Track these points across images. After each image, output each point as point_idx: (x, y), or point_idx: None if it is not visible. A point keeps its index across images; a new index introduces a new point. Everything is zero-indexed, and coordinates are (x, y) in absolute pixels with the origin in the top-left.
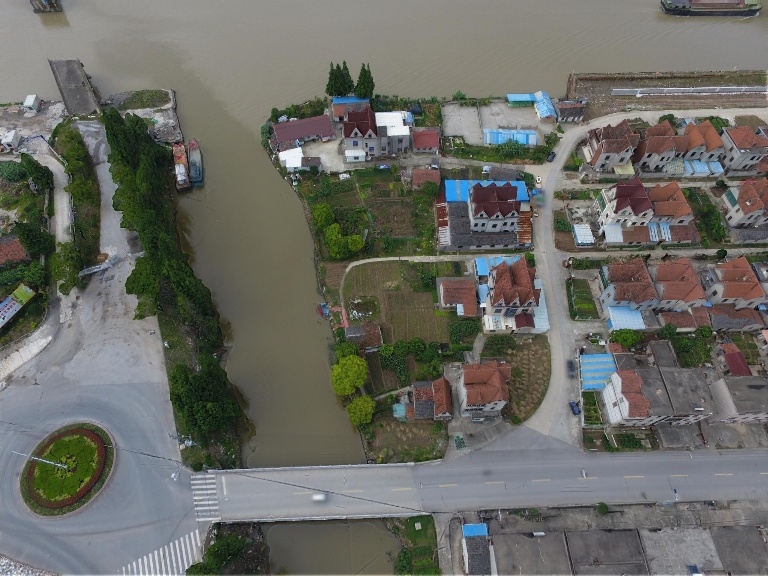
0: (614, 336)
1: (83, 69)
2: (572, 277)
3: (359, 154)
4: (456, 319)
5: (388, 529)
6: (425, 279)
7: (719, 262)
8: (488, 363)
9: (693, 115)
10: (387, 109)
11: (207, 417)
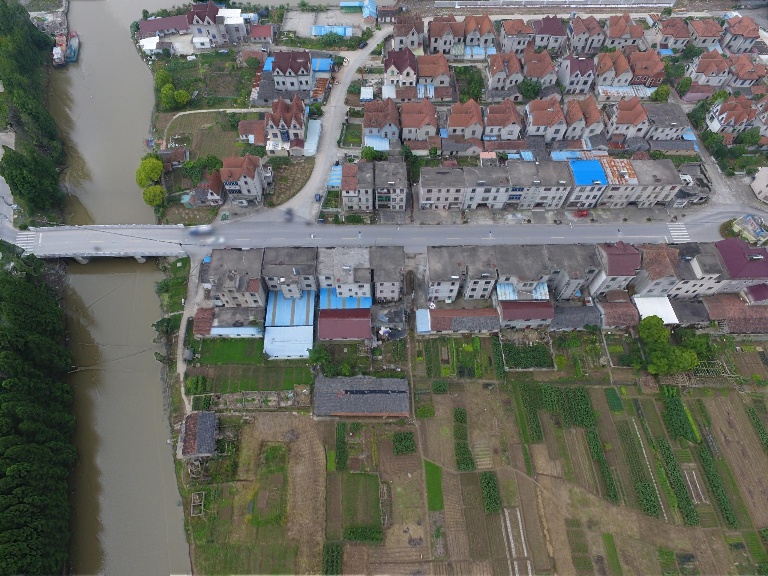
0: (361, 153)
1: None
2: (345, 119)
3: (204, 40)
4: (250, 148)
5: (160, 269)
6: (232, 121)
7: None
8: (244, 156)
9: (493, 19)
10: None
11: (25, 183)
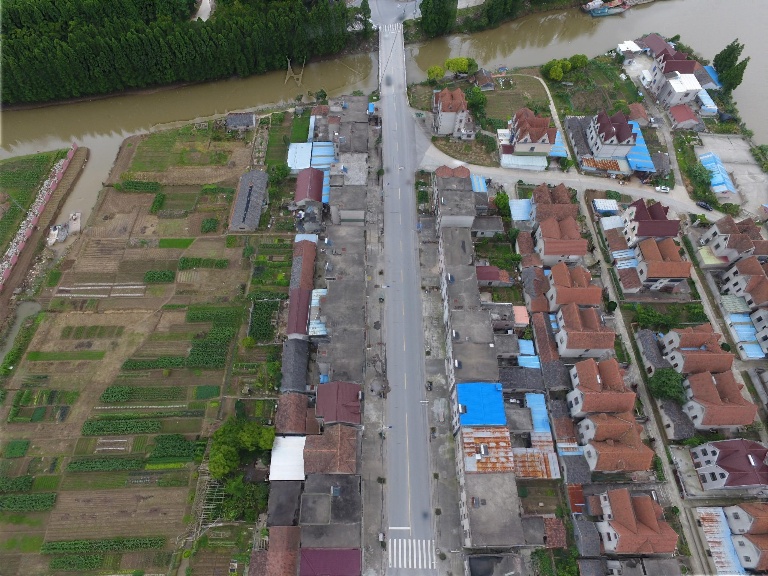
0: None
1: None
2: (555, 184)
3: (647, 77)
4: None
5: None
6: (535, 108)
7: (605, 313)
8: None
9: None
10: (714, 97)
11: (426, 5)
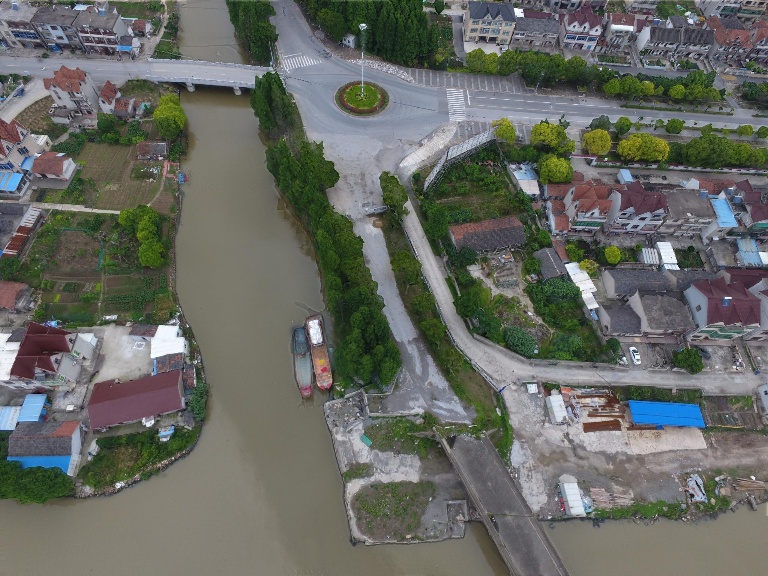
0: None
1: (511, 572)
2: None
3: None
4: None
5: None
6: (77, 184)
7: None
8: (59, 87)
9: None
10: None
11: None
